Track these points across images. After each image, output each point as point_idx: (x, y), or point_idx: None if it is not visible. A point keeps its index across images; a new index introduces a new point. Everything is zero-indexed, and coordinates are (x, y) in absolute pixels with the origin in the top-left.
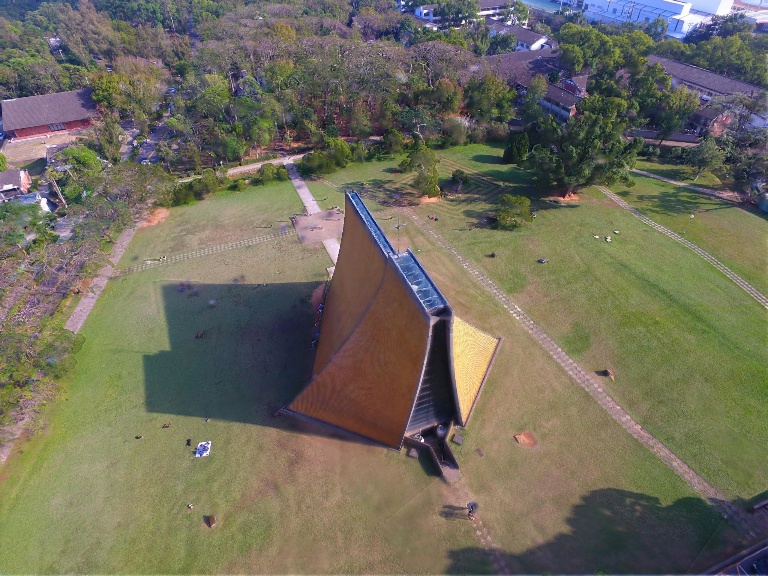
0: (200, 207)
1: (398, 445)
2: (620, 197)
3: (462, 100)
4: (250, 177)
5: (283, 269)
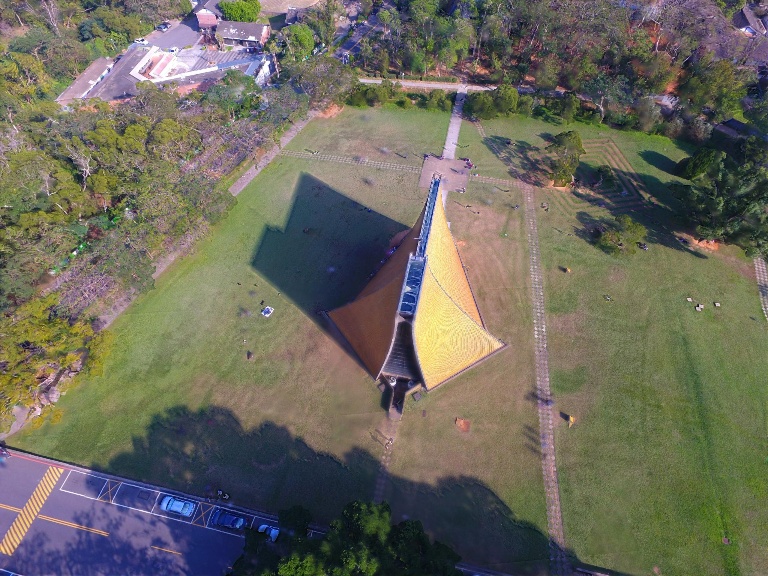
0: (366, 114)
1: (375, 377)
2: (767, 268)
3: (673, 82)
4: (423, 95)
5: (390, 202)
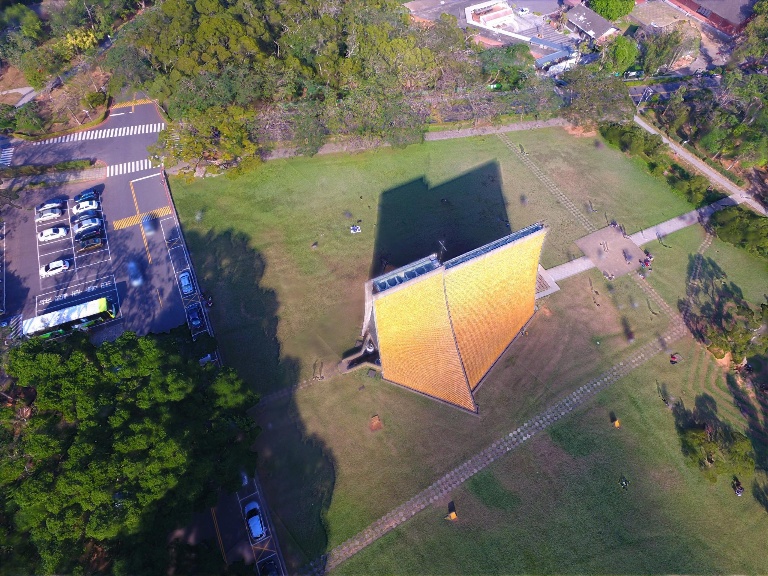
0: (608, 153)
1: None
2: None
3: None
4: (689, 175)
5: None
